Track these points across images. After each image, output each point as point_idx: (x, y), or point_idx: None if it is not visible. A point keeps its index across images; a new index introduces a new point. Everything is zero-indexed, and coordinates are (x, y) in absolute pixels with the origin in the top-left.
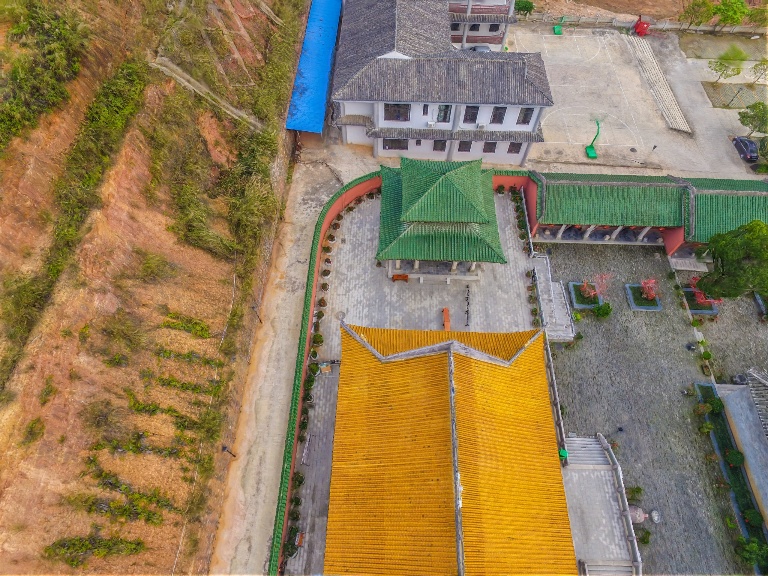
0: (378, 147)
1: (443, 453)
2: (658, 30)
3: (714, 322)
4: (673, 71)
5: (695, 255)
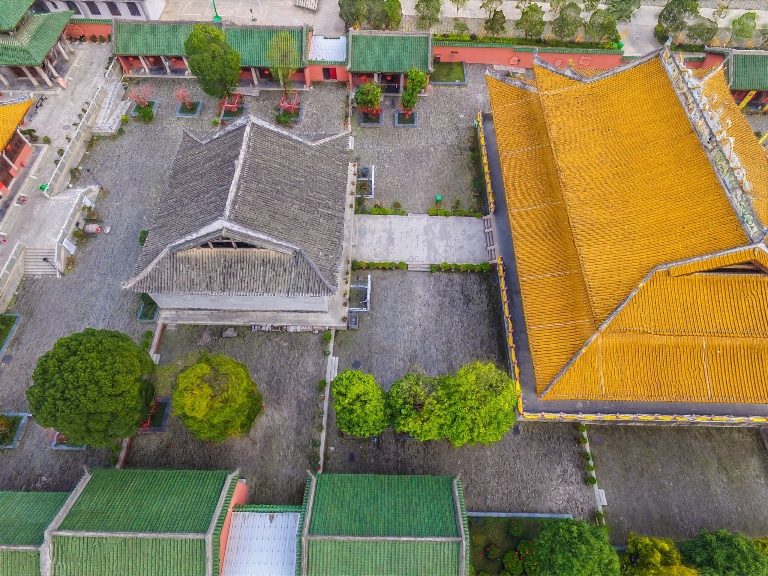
0: None
1: None
2: None
3: None
4: None
5: (252, 84)
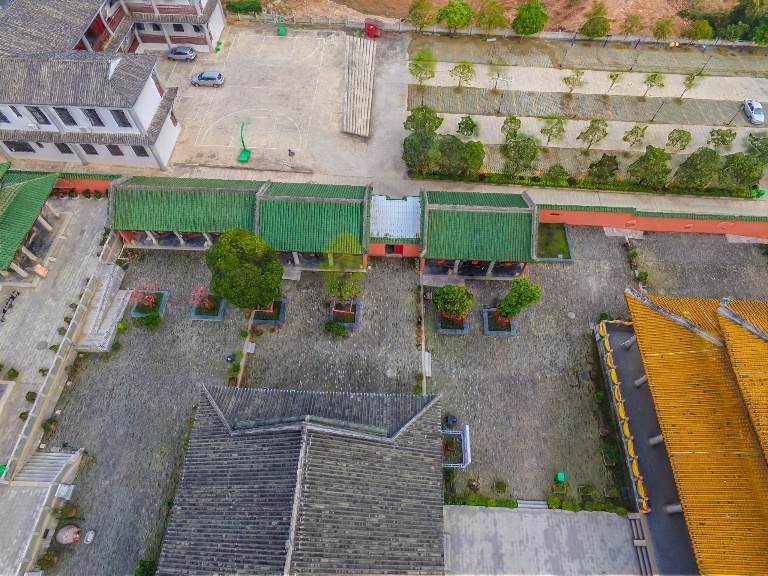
0: (4, 149)
1: None
2: (394, 32)
3: (275, 332)
4: (386, 73)
5: (291, 263)
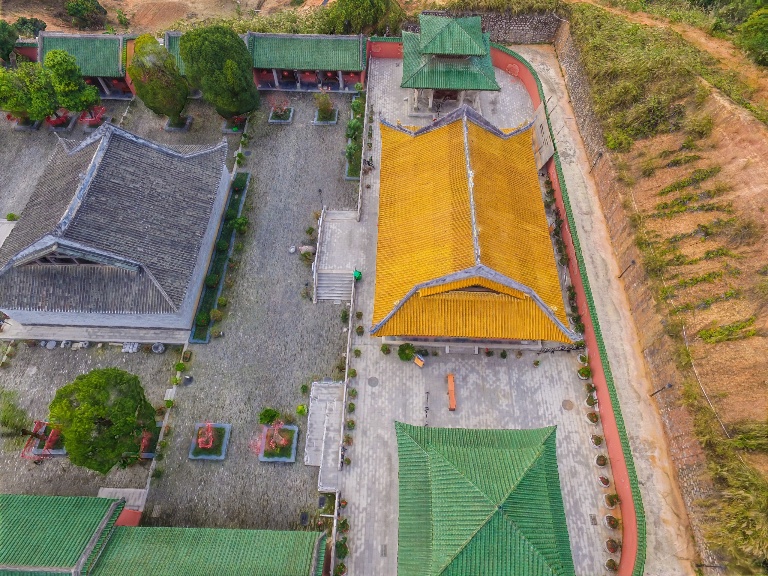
0: None
1: (479, 209)
2: None
3: None
4: None
5: None
